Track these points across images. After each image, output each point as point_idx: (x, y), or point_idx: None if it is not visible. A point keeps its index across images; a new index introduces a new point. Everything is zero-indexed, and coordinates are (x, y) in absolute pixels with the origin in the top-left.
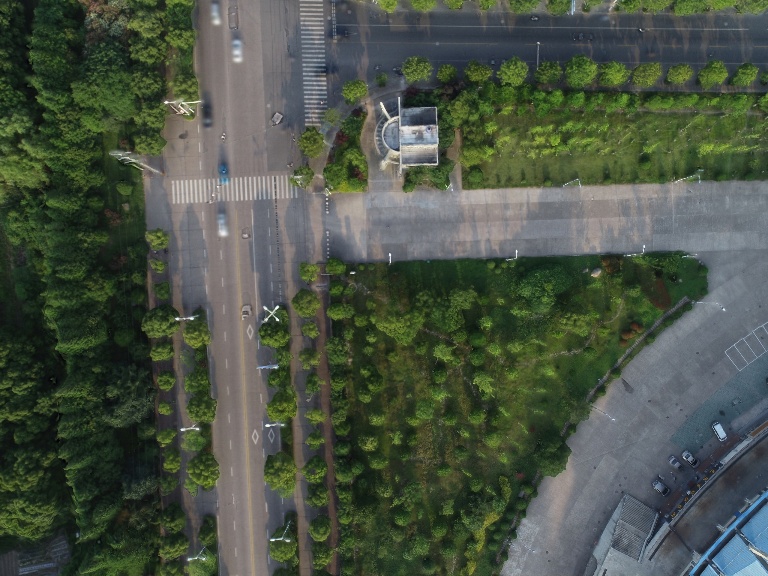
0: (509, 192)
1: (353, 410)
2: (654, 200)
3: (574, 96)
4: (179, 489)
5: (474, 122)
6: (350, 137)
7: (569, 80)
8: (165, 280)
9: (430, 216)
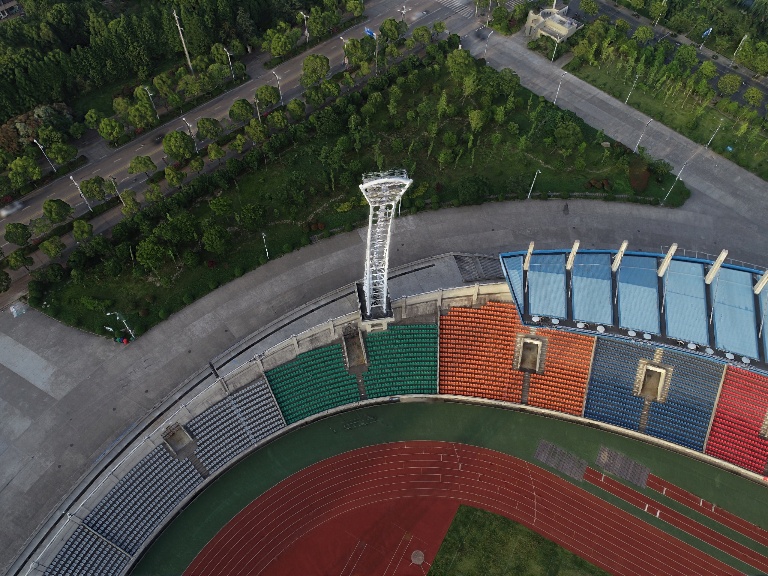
0: (588, 86)
1: (383, 95)
2: (682, 145)
3: (671, 62)
4: (253, 58)
5: (599, 35)
6: (524, 9)
7: (674, 54)
8: (366, 0)
9: (530, 65)
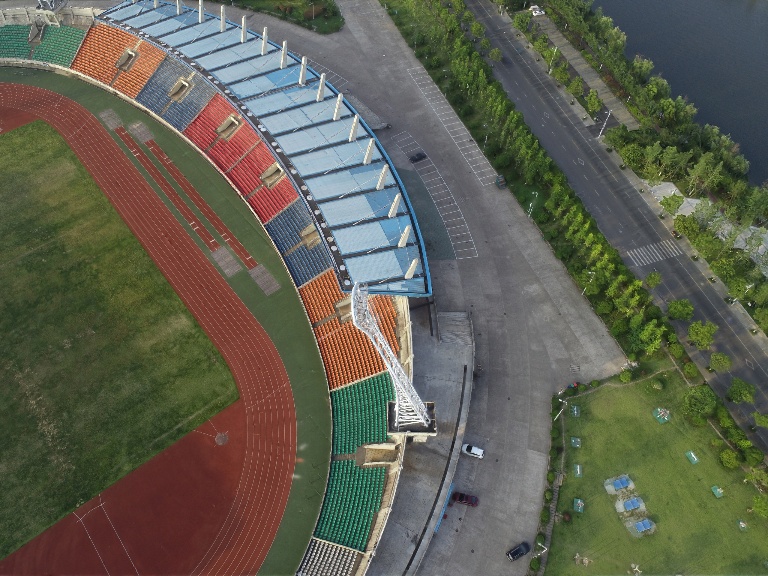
0: None
1: None
2: (370, 5)
3: None
4: None
5: None
6: None
7: None
8: None
9: None
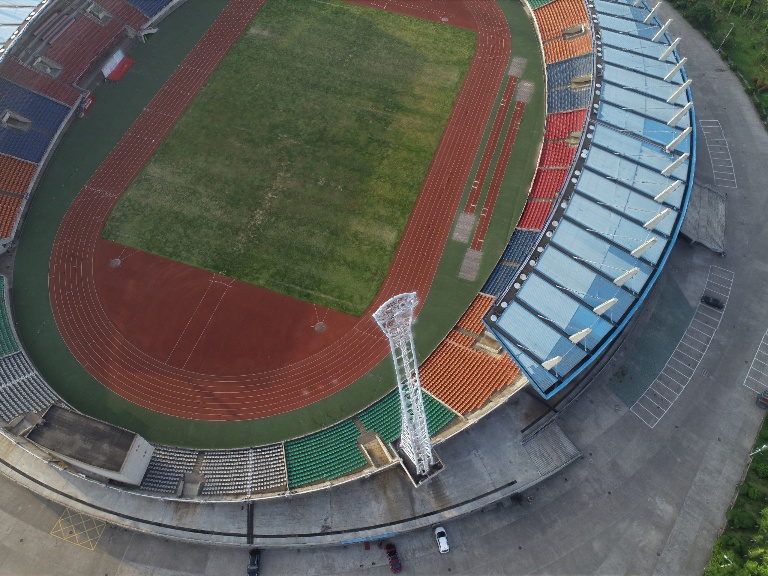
0: None
1: None
2: None
3: None
4: None
5: None
6: None
7: None
8: None
9: None
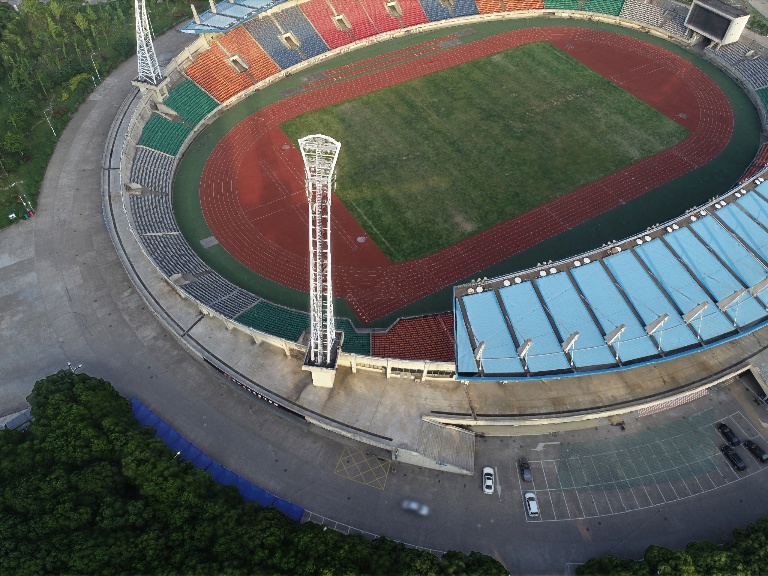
0: None
1: None
2: None
3: None
4: None
5: None
6: None
7: None
8: None
9: None
